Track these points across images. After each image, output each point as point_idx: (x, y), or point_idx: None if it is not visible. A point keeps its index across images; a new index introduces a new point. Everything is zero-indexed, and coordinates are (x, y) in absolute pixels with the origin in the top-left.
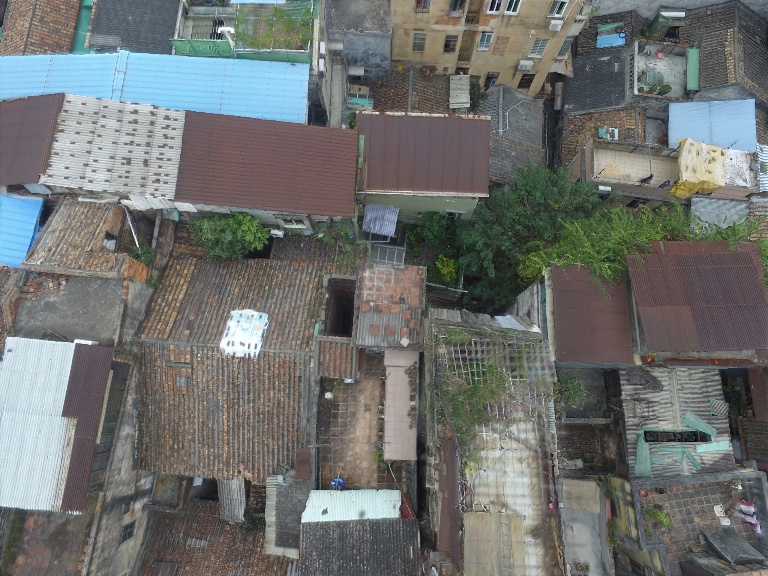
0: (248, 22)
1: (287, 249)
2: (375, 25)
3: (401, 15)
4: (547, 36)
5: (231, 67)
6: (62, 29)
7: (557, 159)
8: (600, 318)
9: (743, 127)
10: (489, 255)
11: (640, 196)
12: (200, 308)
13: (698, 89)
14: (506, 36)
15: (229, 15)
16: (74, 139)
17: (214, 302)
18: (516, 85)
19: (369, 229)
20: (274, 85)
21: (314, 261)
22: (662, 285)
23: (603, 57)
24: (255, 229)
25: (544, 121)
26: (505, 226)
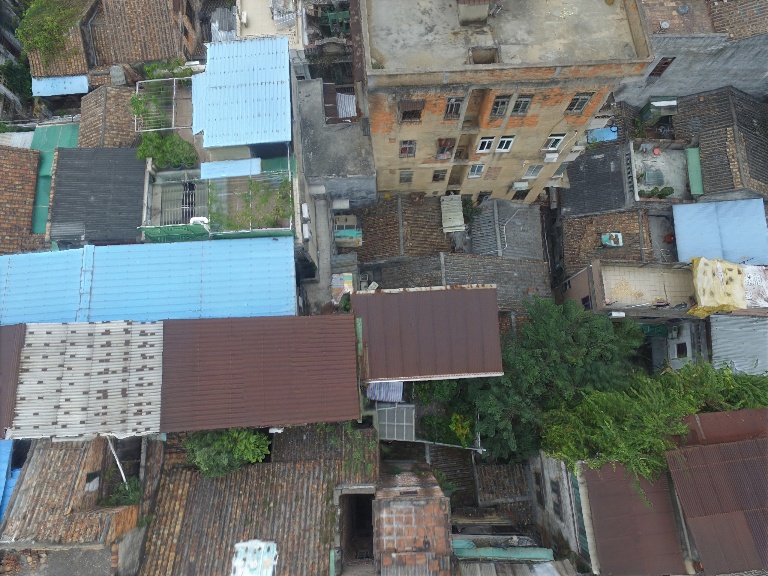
0: (222, 200)
1: (289, 445)
2: (357, 167)
3: (385, 160)
4: (541, 163)
5: (208, 250)
6: (20, 208)
7: (558, 258)
8: (643, 522)
9: (754, 230)
10: (508, 427)
11: (655, 315)
12: (200, 543)
13: (703, 193)
14: (498, 166)
15: (200, 179)
16: (41, 377)
17: (215, 532)
18: (510, 198)
19: (374, 397)
20: (257, 266)
21: (320, 459)
22: (709, 487)
23: (597, 155)
24: (253, 447)
25: (542, 224)
26: (522, 390)
